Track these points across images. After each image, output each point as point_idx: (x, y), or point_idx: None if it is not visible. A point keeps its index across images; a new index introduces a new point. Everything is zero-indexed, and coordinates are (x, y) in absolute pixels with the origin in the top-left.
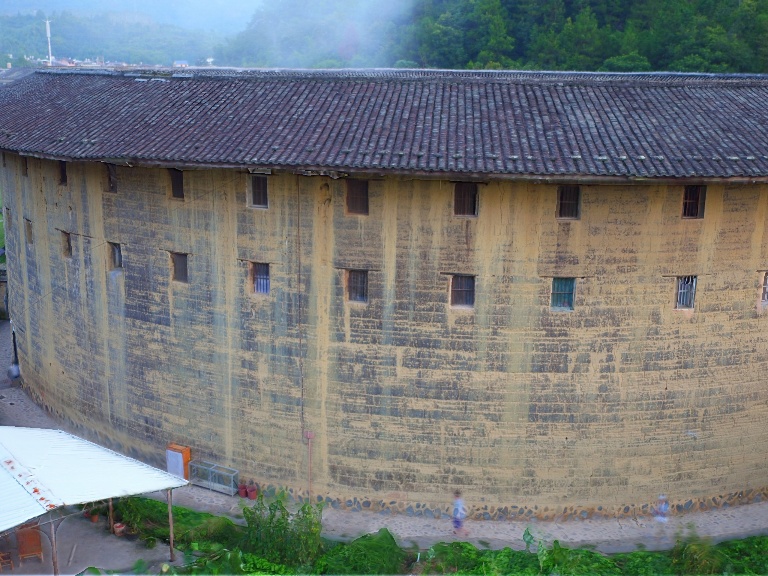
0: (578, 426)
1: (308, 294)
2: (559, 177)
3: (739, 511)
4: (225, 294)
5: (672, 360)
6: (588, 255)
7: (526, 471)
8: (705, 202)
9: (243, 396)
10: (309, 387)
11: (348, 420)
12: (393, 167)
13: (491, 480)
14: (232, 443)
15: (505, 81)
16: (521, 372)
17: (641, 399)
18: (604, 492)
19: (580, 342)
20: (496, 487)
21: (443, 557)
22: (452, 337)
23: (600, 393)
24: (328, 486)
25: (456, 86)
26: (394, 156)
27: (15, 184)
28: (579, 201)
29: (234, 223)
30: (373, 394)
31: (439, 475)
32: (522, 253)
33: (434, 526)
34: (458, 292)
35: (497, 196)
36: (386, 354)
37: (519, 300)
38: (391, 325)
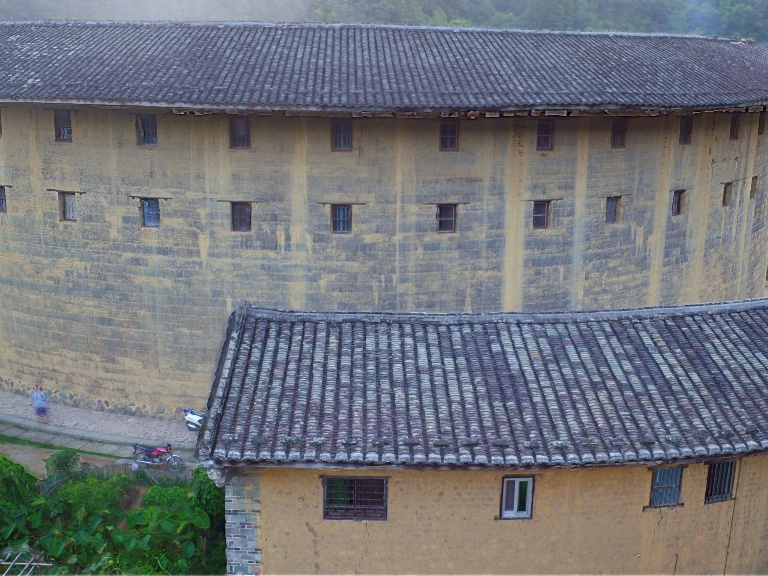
0: None
1: None
2: None
3: None
4: None
5: None
6: None
7: None
8: None
9: None
10: None
11: None
12: None
13: None
14: None
15: None
16: None
17: None
18: None
19: None
20: None
21: None
22: None
23: None
24: None
25: None
26: None
27: (660, 159)
28: None
29: None
30: None
31: None
32: None
33: None
34: None
35: None
36: None
37: None
38: None
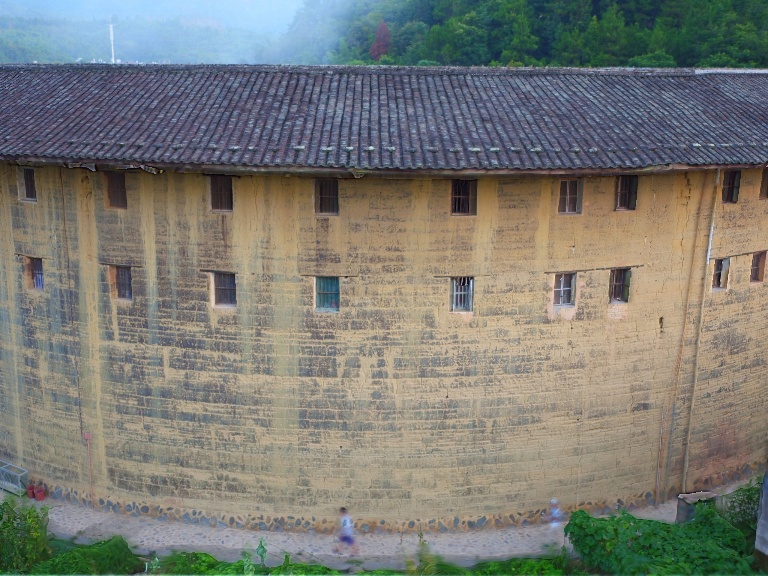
0: (352, 434)
1: (78, 290)
2: (274, 169)
3: (538, 530)
4: (7, 289)
5: (452, 366)
6: (350, 253)
7: (300, 480)
8: (477, 198)
9: (28, 394)
10: (85, 386)
11: (122, 422)
12: (106, 158)
13: (265, 488)
14: (22, 442)
15: (272, 69)
16: (288, 376)
17: (419, 407)
18: (385, 505)
19: (348, 345)
20: (270, 496)
21: (170, 568)
22: (216, 337)
23: (373, 400)
24: (108, 489)
25: (222, 75)
26: (115, 146)
27: None
28: (338, 196)
29: (9, 217)
30: (144, 395)
31: (212, 481)
32: (281, 250)
33: (205, 535)
34: (222, 290)
35: (251, 190)
36: (153, 354)
37: (281, 300)
38: (156, 324)
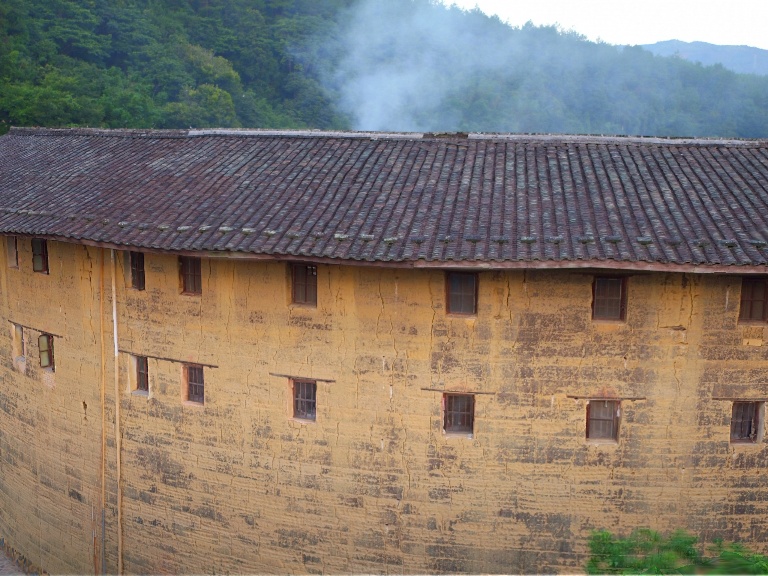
0: None
1: None
2: None
3: (12, 572)
4: None
5: None
6: None
7: None
8: None
9: None
10: None
11: None
12: None
13: None
14: None
15: None
16: None
17: None
18: None
19: None
20: None
21: None
22: None
23: None
24: None
25: None
26: None
27: None
28: None
29: None
30: None
31: None
32: None
33: None
34: None
35: None
36: None
37: None
38: None
